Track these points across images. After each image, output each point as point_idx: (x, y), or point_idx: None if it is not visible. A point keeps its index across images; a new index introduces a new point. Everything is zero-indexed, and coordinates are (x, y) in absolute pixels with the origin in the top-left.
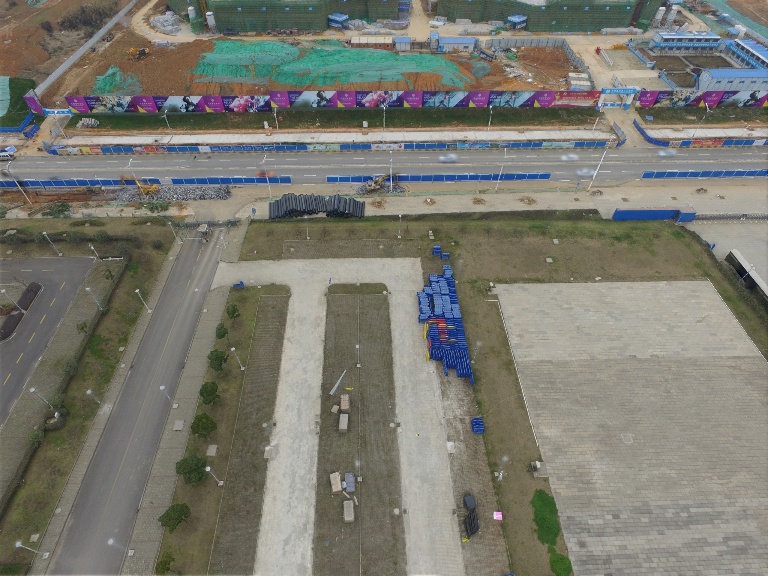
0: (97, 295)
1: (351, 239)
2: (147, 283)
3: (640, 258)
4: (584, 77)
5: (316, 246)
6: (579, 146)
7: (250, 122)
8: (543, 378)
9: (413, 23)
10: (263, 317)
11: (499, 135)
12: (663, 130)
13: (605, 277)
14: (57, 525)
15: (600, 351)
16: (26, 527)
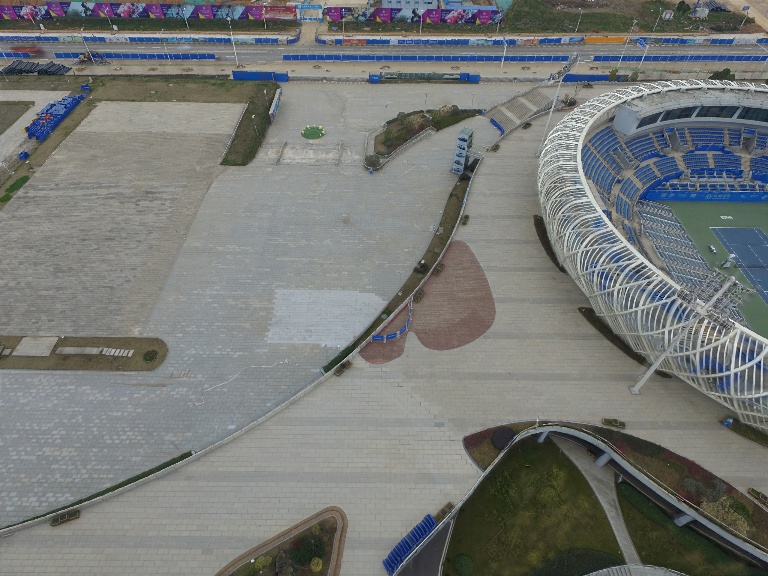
0: None
1: (36, 82)
2: None
3: (215, 93)
4: (300, 0)
5: (9, 84)
6: (259, 42)
7: (33, 26)
8: (82, 138)
9: None
10: None
11: (211, 36)
12: (337, 36)
13: (179, 100)
14: None
15: (132, 129)
16: None
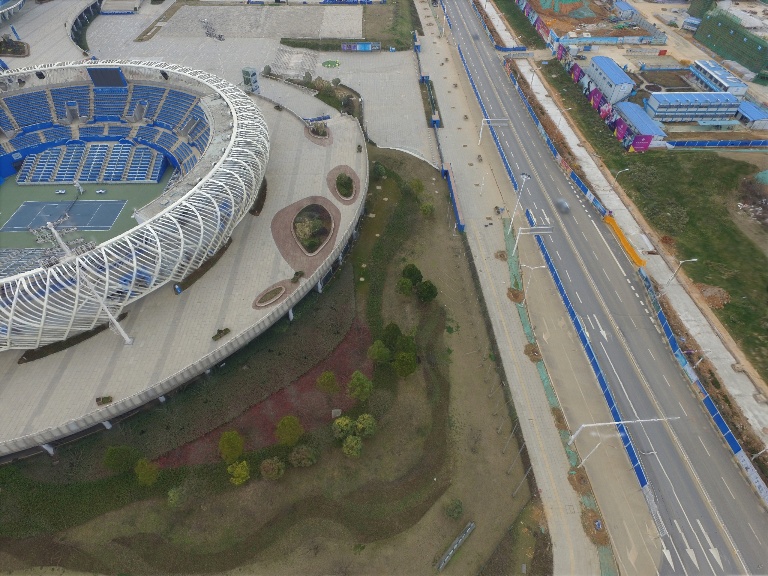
0: None
1: None
2: None
3: None
4: (584, 36)
5: None
6: None
7: None
8: (318, 8)
9: (666, 4)
10: None
11: (500, 25)
12: (530, 66)
13: None
14: None
15: None
16: None
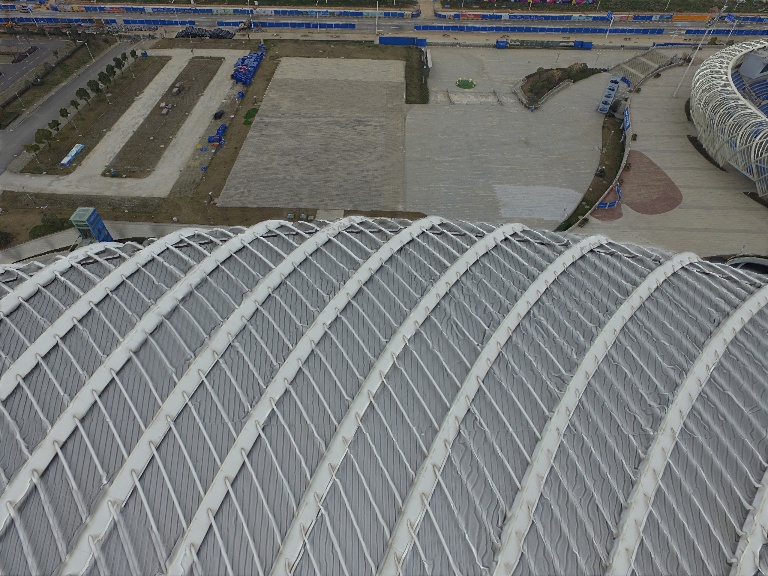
0: (67, 52)
1: (216, 43)
2: (96, 53)
3: (374, 52)
4: None
5: (194, 44)
6: (387, 16)
7: (183, 1)
8: (282, 83)
9: None
10: (153, 64)
11: None
12: (452, 12)
13: (347, 57)
14: (34, 107)
15: (320, 77)
16: (21, 106)
